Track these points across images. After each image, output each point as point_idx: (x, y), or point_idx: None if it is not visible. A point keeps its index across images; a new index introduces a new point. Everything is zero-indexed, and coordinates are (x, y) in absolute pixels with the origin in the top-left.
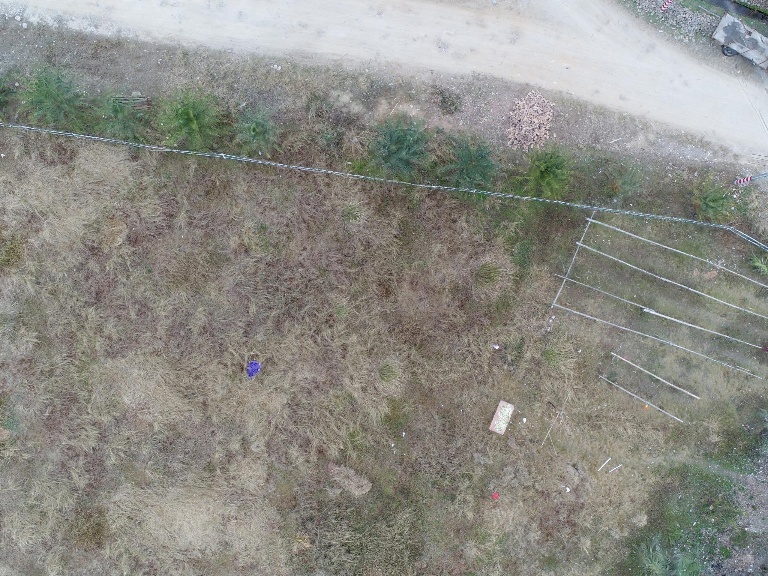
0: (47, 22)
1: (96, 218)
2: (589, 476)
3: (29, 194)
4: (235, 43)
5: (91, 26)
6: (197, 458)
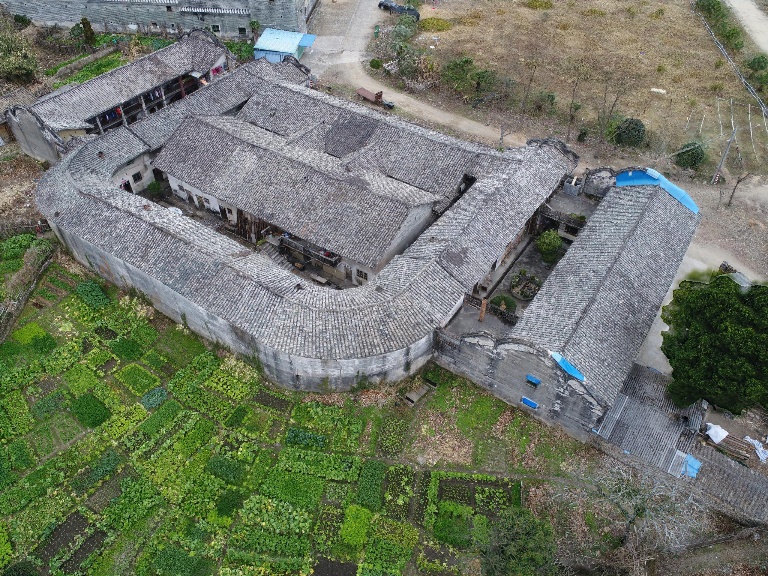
0: (743, 24)
1: (679, 29)
2: (641, 117)
3: None
4: (766, 51)
5: (748, 30)
6: (601, 44)
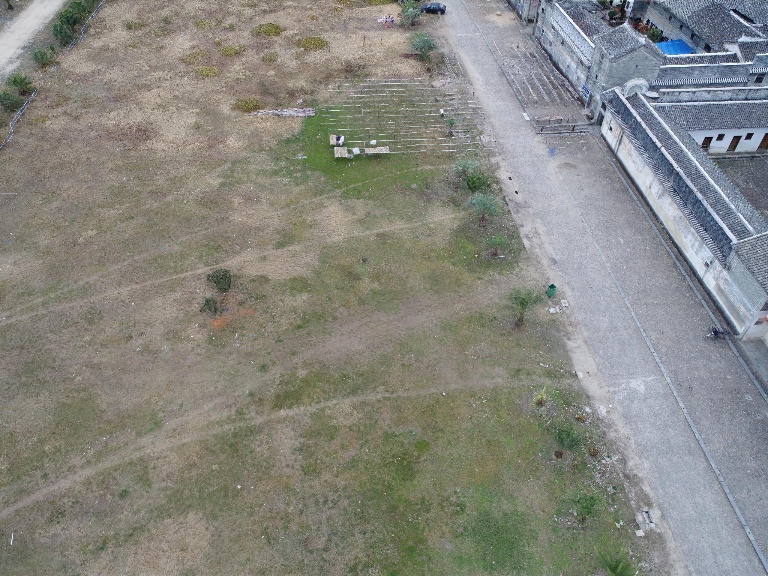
0: (44, 25)
1: None
2: None
3: (116, 23)
4: None
5: None
6: None
